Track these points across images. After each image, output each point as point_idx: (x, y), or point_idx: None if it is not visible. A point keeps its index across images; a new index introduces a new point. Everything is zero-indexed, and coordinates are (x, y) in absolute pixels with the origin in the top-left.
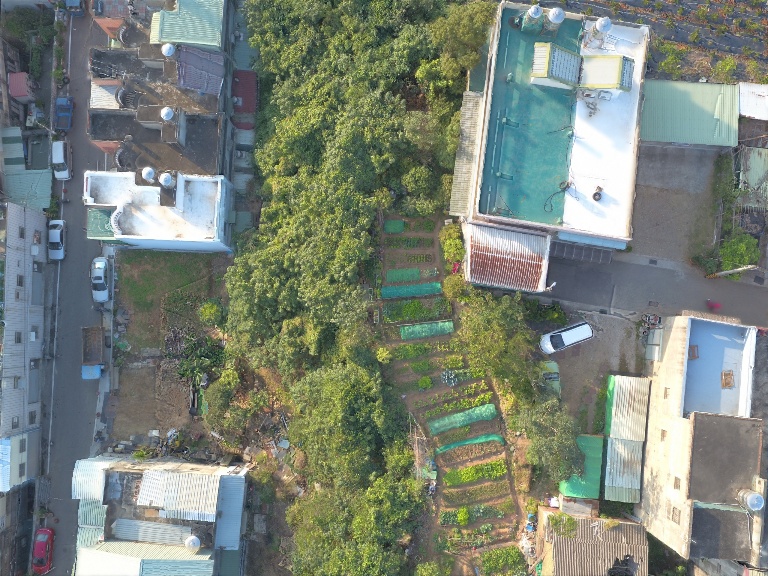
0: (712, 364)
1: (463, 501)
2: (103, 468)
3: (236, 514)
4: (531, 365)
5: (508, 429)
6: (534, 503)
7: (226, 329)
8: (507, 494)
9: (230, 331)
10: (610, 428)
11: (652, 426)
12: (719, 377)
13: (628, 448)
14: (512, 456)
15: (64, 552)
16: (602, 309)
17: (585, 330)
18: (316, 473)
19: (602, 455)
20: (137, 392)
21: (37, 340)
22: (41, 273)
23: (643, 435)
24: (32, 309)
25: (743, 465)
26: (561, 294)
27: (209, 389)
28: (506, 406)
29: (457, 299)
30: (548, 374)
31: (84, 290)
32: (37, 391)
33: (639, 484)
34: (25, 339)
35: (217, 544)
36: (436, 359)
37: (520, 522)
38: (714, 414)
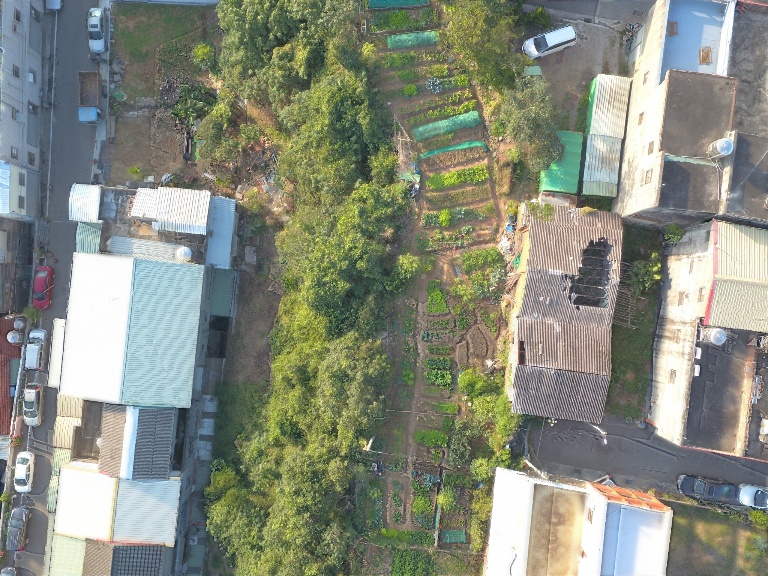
0: (691, 41)
1: (445, 204)
2: (98, 185)
3: (227, 235)
4: (513, 54)
5: (491, 135)
6: (514, 205)
7: (219, 74)
8: (488, 198)
9: (223, 73)
10: (590, 126)
11: (631, 120)
12: (697, 53)
13: (607, 144)
14: (494, 162)
15: (63, 290)
16: (587, 18)
17: (568, 31)
18: (304, 194)
19: (581, 152)
20: (133, 140)
21: (35, 84)
22: (39, 23)
23: (622, 132)
24: (30, 51)
25: (715, 121)
26: (546, 2)
27: (202, 123)
28: (489, 110)
29: (444, 9)
30: (531, 77)
31: (81, 41)
32: (36, 137)
33: (616, 179)
34: (23, 76)
35: (208, 261)
36: (422, 67)
37: (500, 225)
38: (689, 71)
